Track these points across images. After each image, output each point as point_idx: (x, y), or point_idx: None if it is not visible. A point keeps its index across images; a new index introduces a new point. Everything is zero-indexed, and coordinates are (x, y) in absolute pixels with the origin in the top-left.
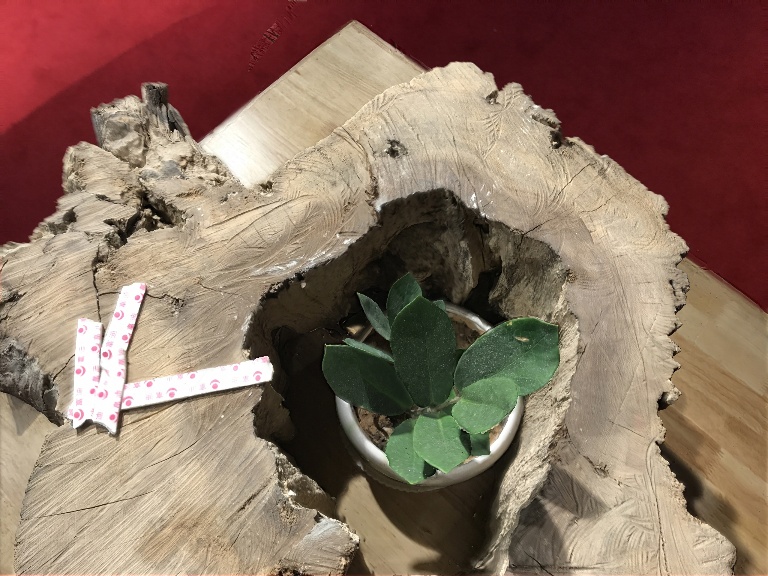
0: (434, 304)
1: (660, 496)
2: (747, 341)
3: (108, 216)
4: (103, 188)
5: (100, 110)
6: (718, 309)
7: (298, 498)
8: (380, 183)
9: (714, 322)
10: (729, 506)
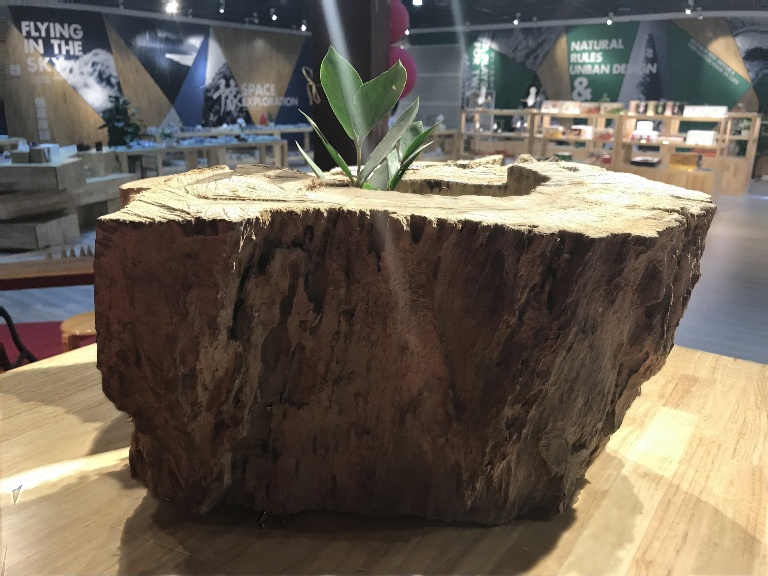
0: None
1: (289, 203)
2: None
3: None
4: None
5: None
6: None
7: None
8: None
9: None
10: None
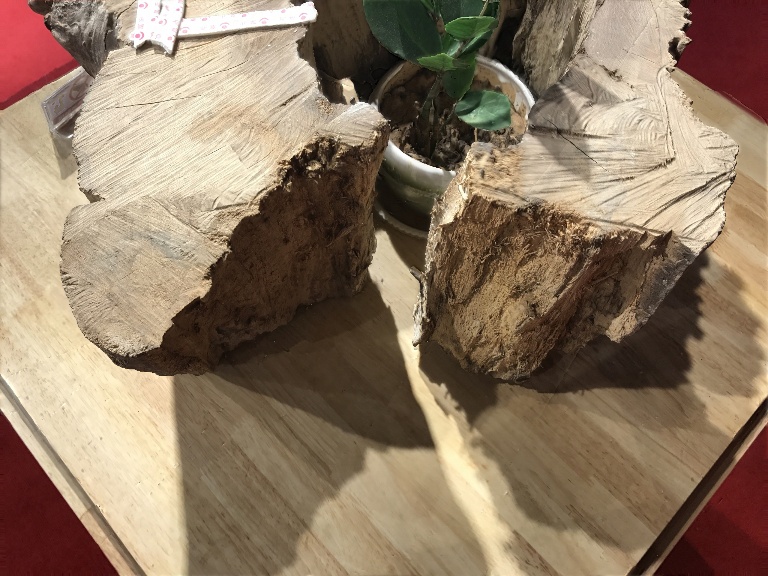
0: None
1: (669, 102)
2: (755, 145)
3: None
4: None
5: None
6: (727, 119)
7: None
8: None
9: (723, 128)
10: (734, 275)
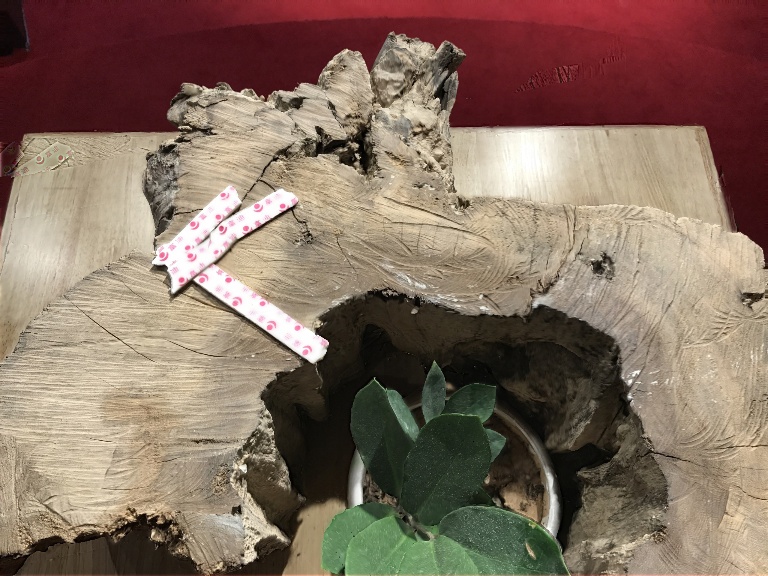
0: (487, 436)
1: None
2: None
3: (322, 125)
4: (339, 100)
5: (397, 38)
6: None
7: (253, 475)
8: (558, 284)
9: None
10: None
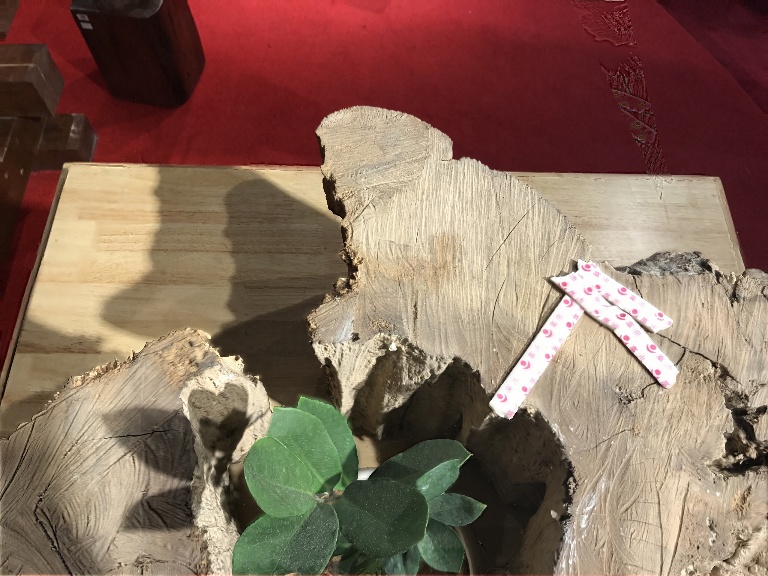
0: (405, 550)
1: None
2: None
3: None
4: None
5: None
6: None
7: None
8: None
9: None
10: None
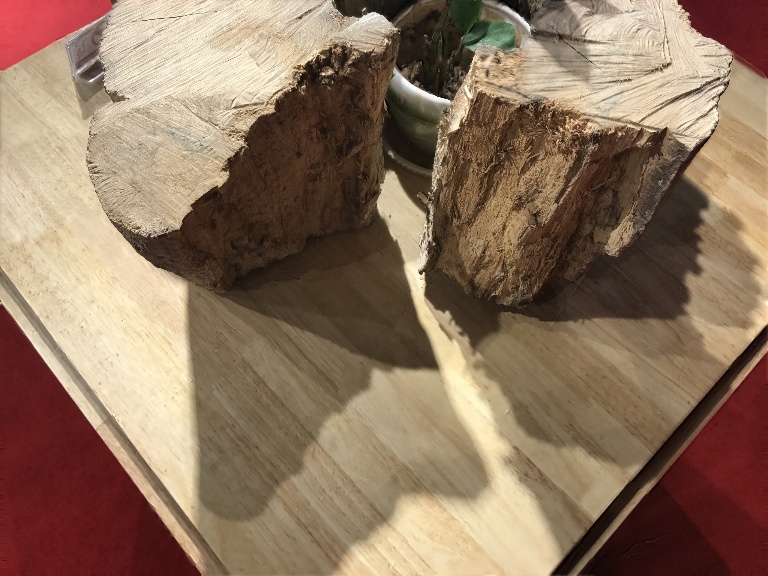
0: None
1: (667, 16)
2: (755, 97)
3: None
4: None
5: None
6: None
7: None
8: None
9: None
10: (733, 216)
